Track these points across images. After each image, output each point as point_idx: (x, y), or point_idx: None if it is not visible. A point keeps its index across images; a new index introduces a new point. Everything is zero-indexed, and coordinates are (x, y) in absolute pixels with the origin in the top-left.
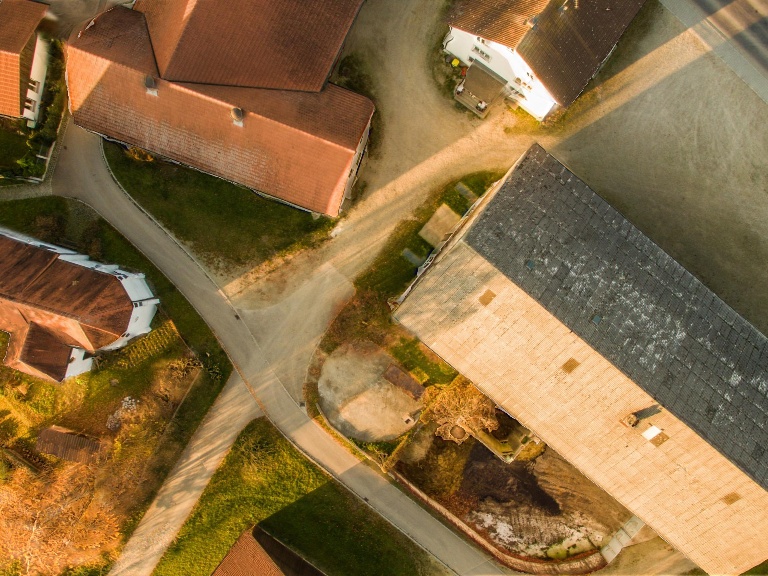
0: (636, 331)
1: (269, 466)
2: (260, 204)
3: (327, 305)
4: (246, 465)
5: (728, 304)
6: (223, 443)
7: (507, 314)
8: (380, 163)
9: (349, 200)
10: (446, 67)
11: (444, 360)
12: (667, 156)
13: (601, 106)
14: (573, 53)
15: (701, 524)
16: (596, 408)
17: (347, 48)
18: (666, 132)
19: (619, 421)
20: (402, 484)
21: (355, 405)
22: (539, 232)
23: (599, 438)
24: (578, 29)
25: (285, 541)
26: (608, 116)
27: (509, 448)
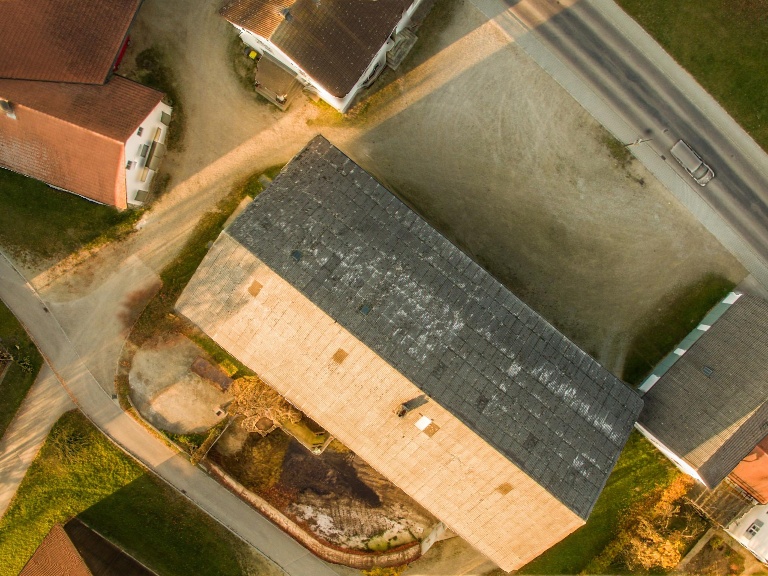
0: (408, 321)
1: (84, 458)
2: (65, 197)
3: (135, 298)
4: (61, 457)
5: (516, 295)
6: (37, 435)
7: (275, 305)
8: (183, 156)
9: (148, 192)
10: (247, 59)
11: (227, 351)
12: (471, 148)
13: (403, 98)
14: (340, 44)
15: (482, 514)
16: (370, 398)
17: (140, 41)
18: (470, 123)
19: (392, 411)
20: (214, 476)
21: (166, 397)
22: (311, 223)
23: (377, 429)
24: (342, 20)
25: (104, 533)
26: (411, 108)
27: (322, 440)
